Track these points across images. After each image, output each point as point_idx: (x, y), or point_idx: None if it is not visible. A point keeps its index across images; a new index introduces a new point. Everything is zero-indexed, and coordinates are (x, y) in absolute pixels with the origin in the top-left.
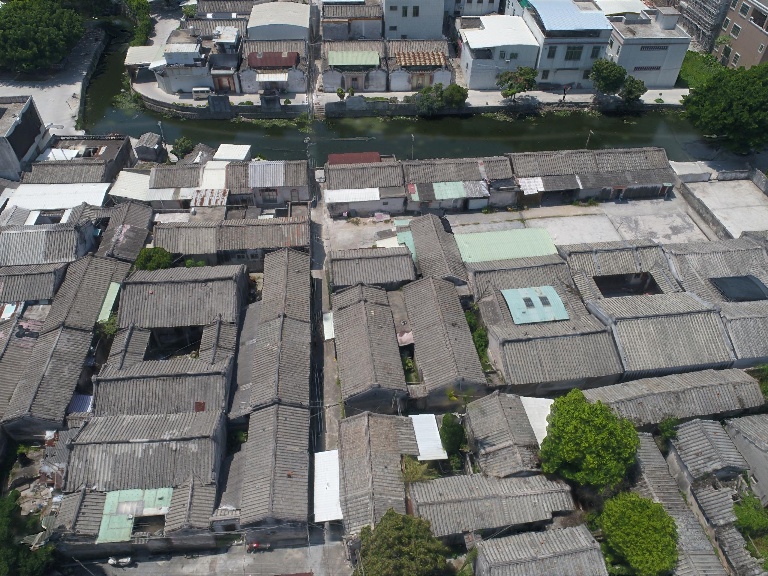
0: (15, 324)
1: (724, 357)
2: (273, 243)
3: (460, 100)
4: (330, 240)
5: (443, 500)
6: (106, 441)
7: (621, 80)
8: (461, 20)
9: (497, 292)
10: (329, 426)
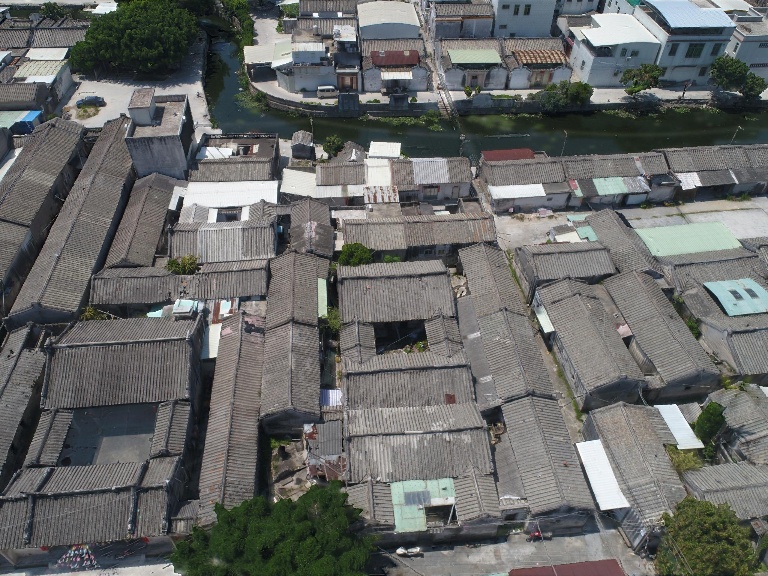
0: (242, 320)
1: None
2: (461, 238)
3: (586, 97)
4: (501, 236)
5: (725, 487)
6: (382, 433)
7: (744, 77)
8: (568, 18)
9: (699, 285)
10: (565, 417)
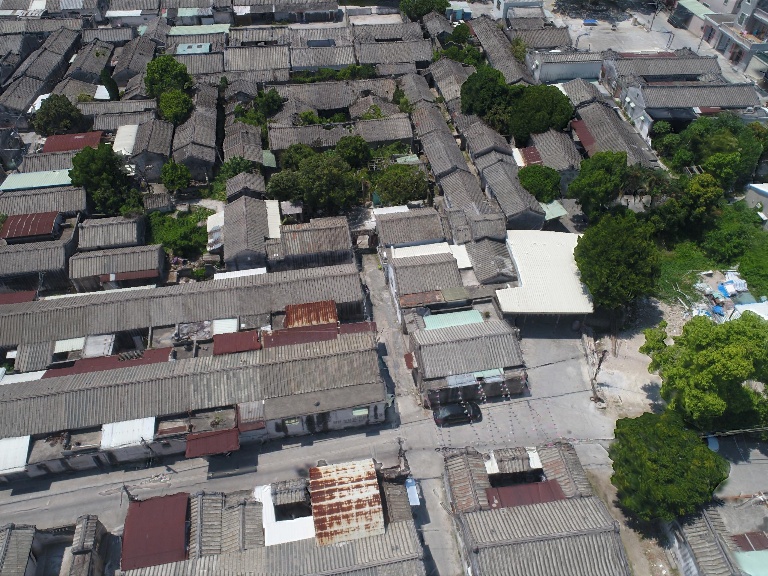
0: None
1: (284, 66)
2: None
3: None
4: None
5: None
6: None
7: None
8: None
9: None
10: None
